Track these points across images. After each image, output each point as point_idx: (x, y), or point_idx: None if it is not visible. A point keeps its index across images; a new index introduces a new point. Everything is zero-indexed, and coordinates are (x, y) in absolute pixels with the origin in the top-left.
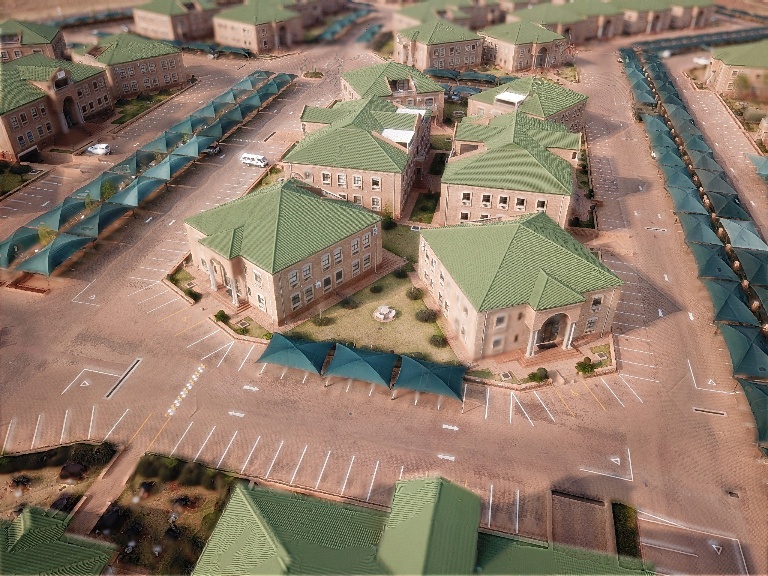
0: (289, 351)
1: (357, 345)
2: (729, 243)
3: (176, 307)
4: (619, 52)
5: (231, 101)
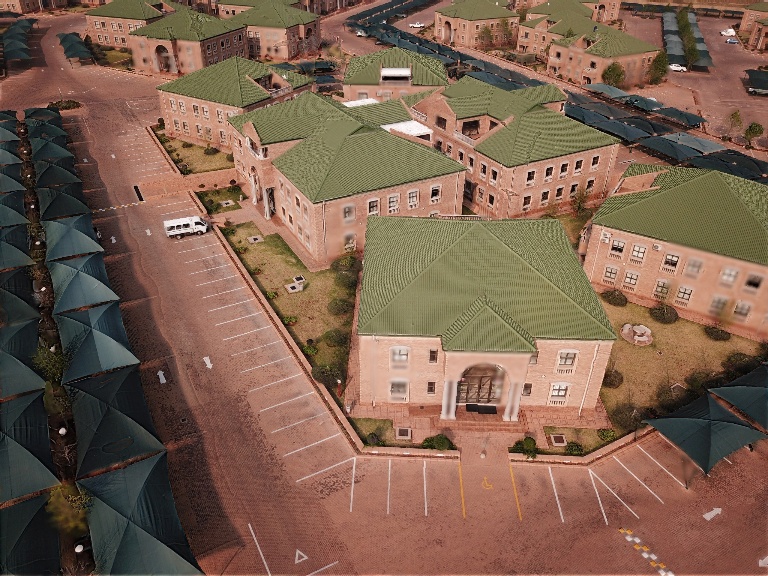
0: (716, 430)
1: (681, 383)
2: (701, 152)
3: (446, 477)
4: (349, 28)
5: (13, 161)
